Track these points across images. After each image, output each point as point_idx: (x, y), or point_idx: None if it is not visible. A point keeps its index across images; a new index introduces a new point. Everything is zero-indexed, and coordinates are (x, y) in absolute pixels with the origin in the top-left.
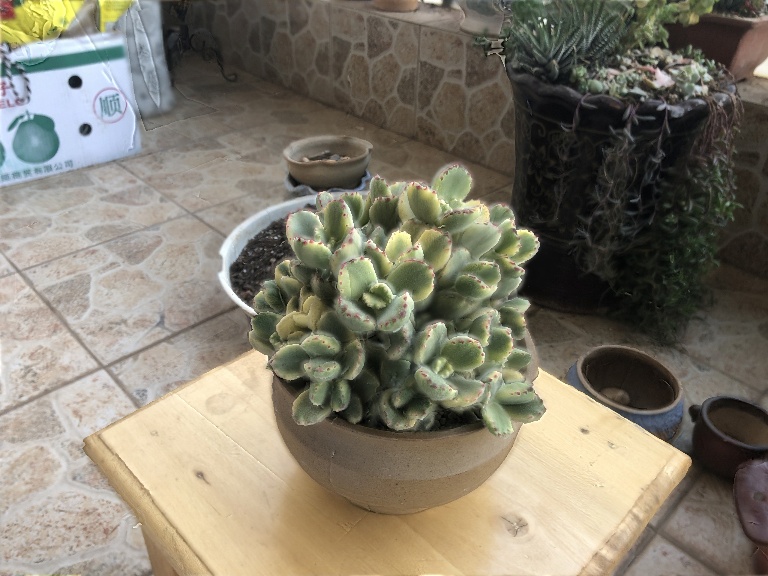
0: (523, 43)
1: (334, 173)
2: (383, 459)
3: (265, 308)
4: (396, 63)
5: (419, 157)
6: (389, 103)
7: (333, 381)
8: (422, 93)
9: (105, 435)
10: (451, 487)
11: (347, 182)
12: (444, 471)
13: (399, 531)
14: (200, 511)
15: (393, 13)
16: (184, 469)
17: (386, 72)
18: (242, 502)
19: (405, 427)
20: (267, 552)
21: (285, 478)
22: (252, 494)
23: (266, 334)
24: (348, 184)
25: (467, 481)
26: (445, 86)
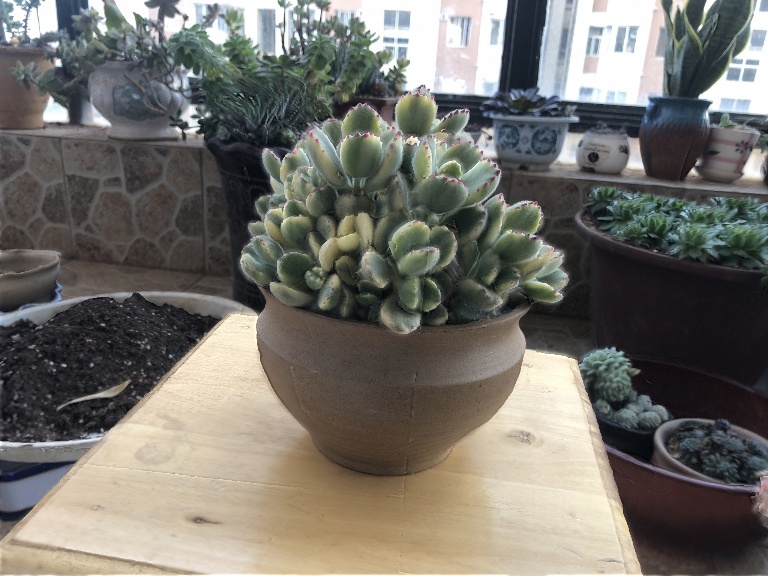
0: (230, 113)
1: (25, 285)
2: (464, 363)
3: (260, 267)
4: (35, 182)
5: (90, 273)
6: (34, 226)
7: (426, 274)
8: (75, 208)
9: (21, 537)
10: (512, 381)
11: (41, 295)
12: (508, 362)
13: (445, 478)
14: (233, 550)
15: (19, 130)
16: (172, 523)
17: (24, 193)
18: (273, 522)
19: (501, 301)
20: (346, 548)
21: (298, 484)
22: (277, 511)
23: (293, 279)
24: (42, 298)
25: (517, 374)
26: (103, 196)
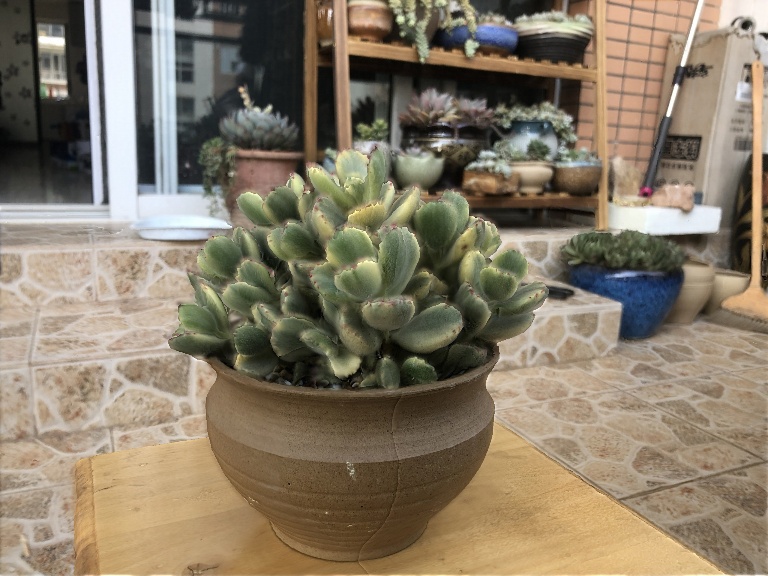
0: None
1: None
2: None
3: None
4: None
5: None
6: None
7: None
8: None
9: None
10: None
11: None
12: None
13: None
14: None
15: None
16: None
17: None
18: None
19: None
20: None
21: None
22: None
23: None
24: None
25: None
26: None
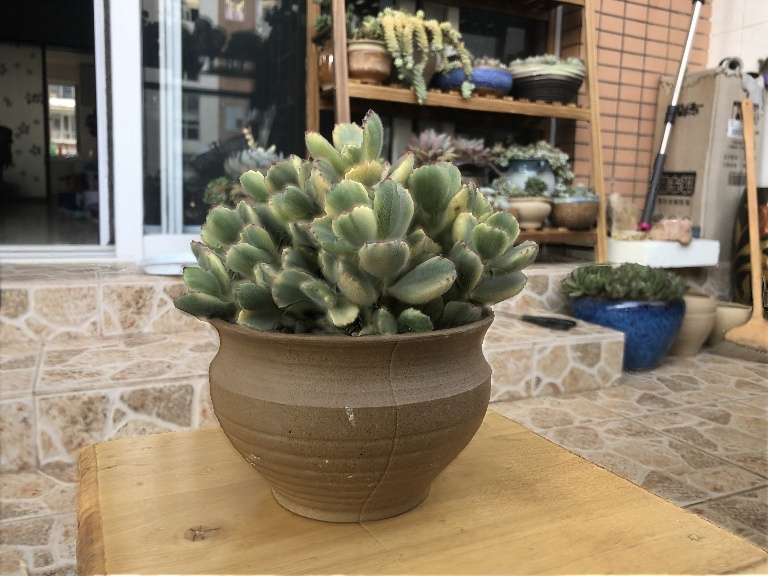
0: None
1: None
2: None
3: None
4: None
5: None
6: None
7: None
8: None
9: None
10: None
11: None
12: None
13: None
14: None
15: None
16: None
17: None
18: None
19: None
20: None
21: None
22: None
23: None
24: None
25: None
26: None
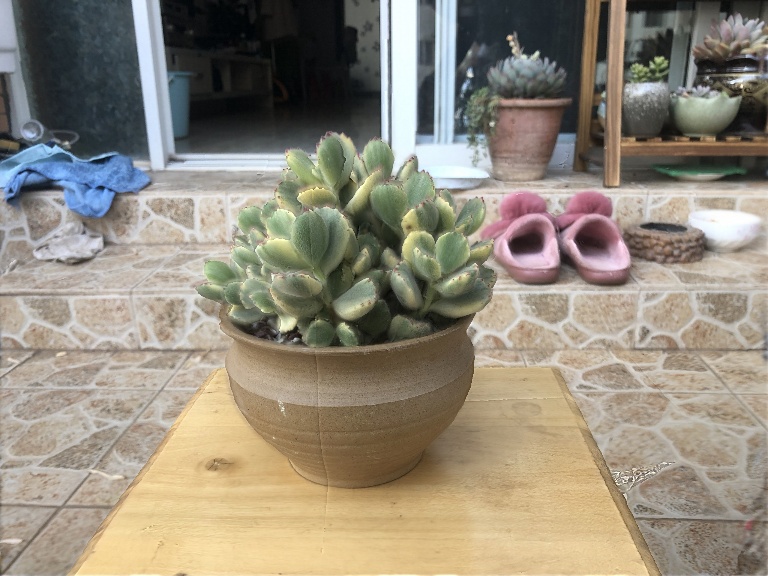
0: None
1: None
2: None
3: None
4: None
5: None
6: None
7: None
8: None
9: None
10: None
11: None
12: None
13: None
14: None
15: None
16: None
17: None
18: None
19: None
20: None
21: None
22: None
23: None
24: None
25: None
26: None
